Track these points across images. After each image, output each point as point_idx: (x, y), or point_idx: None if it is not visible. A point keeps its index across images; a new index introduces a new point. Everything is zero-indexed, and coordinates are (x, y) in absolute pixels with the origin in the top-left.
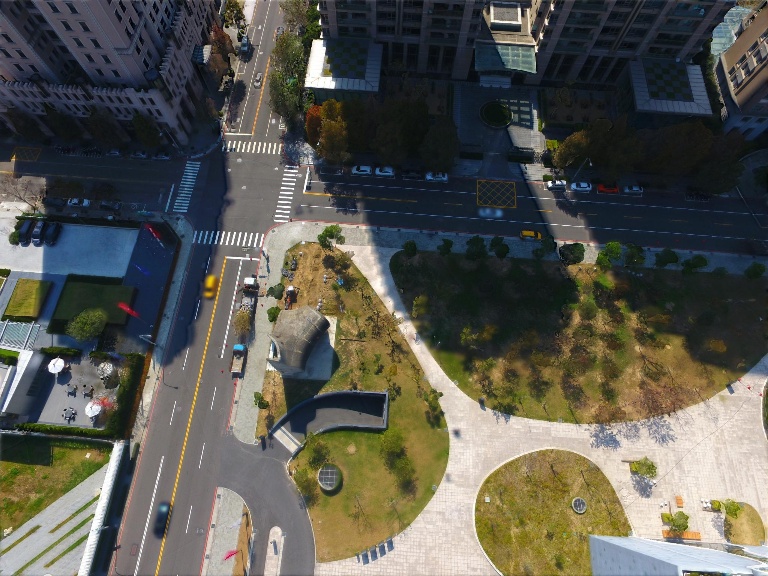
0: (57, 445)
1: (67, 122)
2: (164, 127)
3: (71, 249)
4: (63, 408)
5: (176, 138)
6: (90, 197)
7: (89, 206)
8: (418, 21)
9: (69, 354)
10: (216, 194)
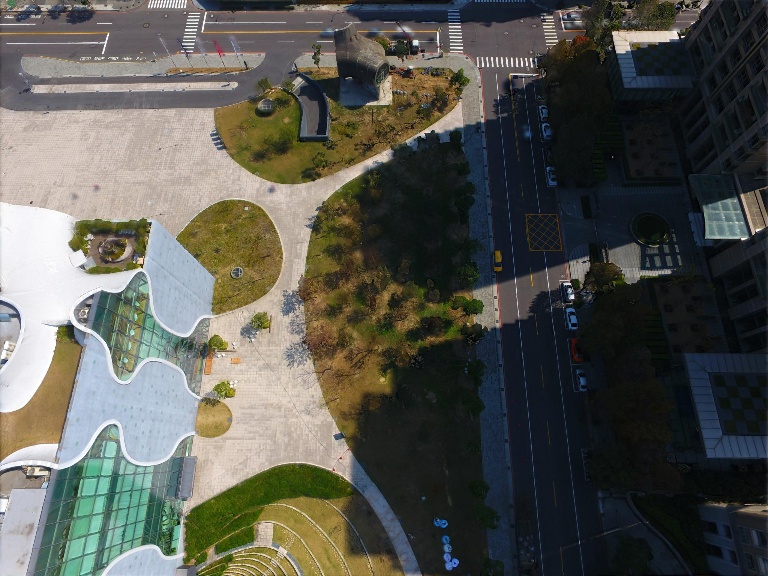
0: None
1: None
2: None
3: None
4: None
5: None
6: None
7: None
8: None
9: None
10: (496, 16)
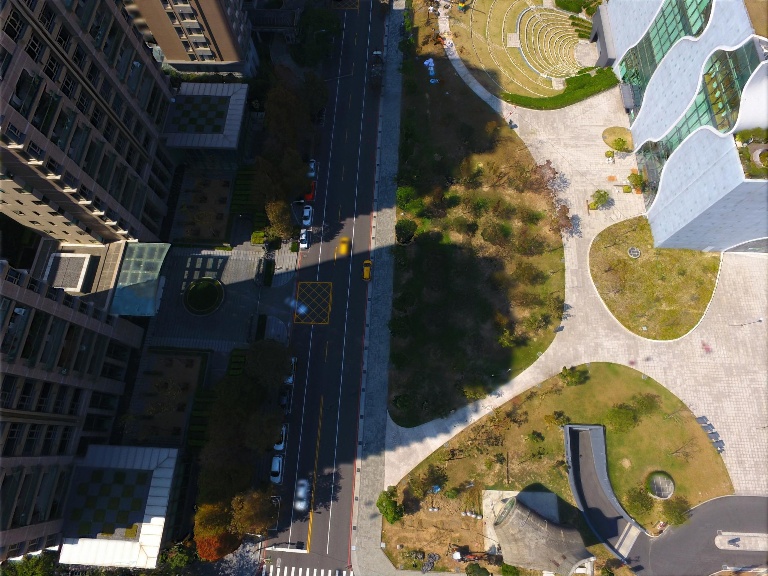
0: None
1: None
2: None
3: None
4: None
5: None
6: None
7: None
8: (66, 391)
9: None
10: None
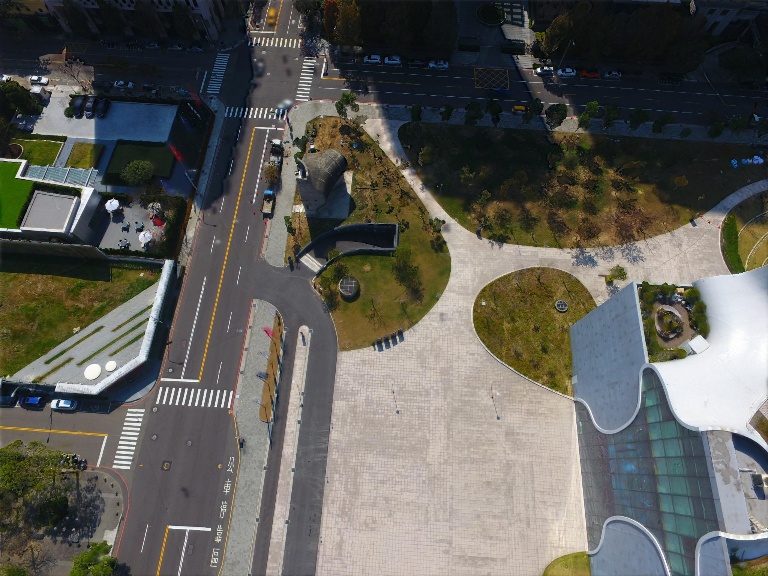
0: (115, 266)
1: (114, 13)
2: (197, 24)
3: (119, 121)
4: (118, 240)
5: (208, 32)
6: (133, 81)
7: (133, 88)
8: None
9: (122, 197)
10: (244, 79)
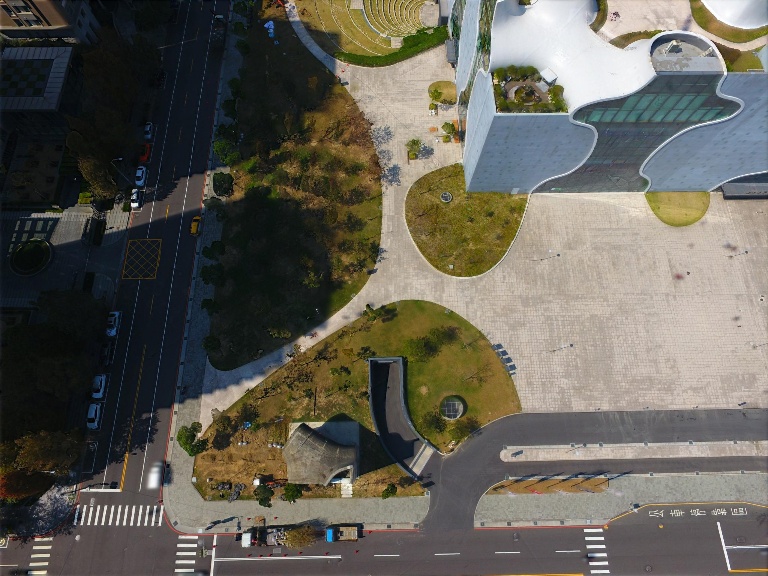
0: None
1: None
2: None
3: None
4: None
5: None
6: None
7: None
8: None
9: None
10: None
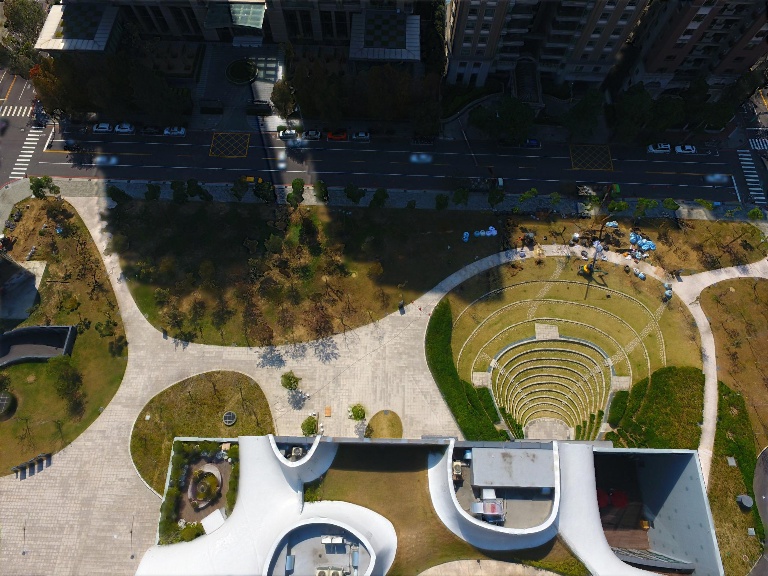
0: None
1: None
2: None
3: None
4: None
5: None
6: None
7: None
8: None
9: None
10: None
